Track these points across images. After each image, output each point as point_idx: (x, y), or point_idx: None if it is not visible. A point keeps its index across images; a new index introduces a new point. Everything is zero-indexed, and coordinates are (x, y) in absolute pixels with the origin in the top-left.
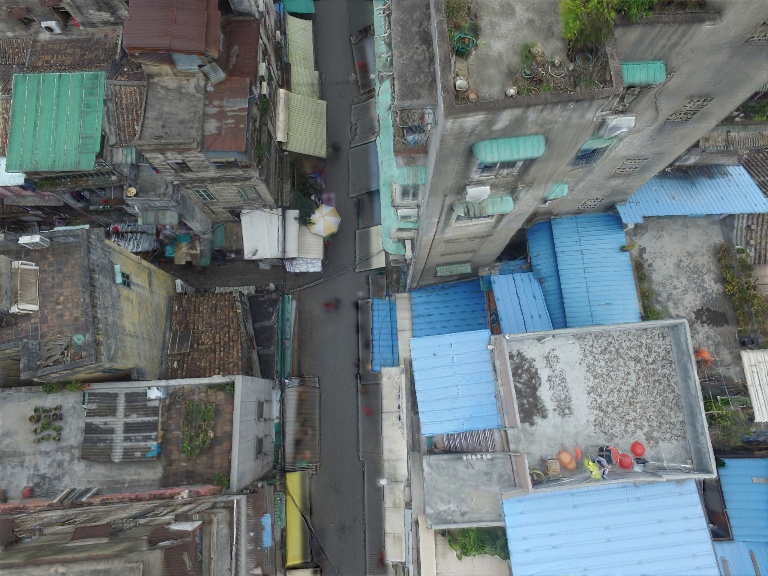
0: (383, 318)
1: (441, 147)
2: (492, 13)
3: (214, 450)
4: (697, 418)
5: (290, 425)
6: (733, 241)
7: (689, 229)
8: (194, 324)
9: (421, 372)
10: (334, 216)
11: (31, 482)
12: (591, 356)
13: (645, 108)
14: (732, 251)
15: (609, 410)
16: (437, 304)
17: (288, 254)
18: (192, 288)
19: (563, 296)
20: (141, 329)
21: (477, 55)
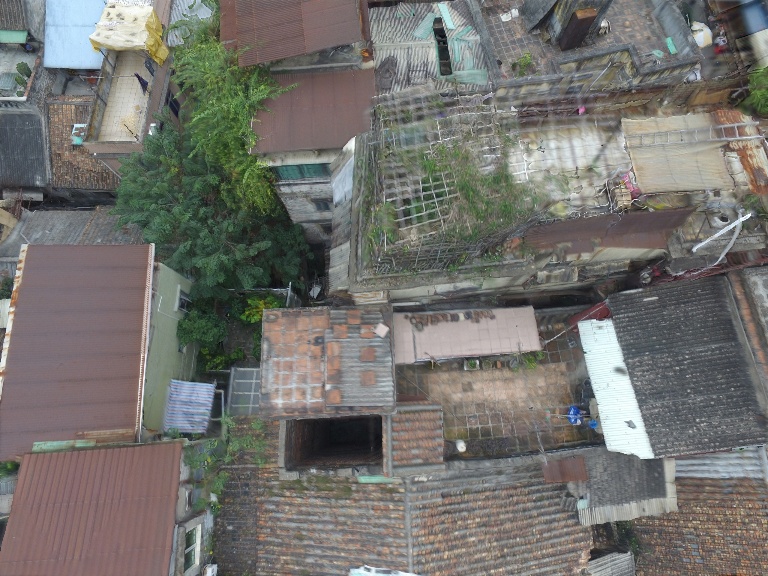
0: None
1: None
2: None
3: None
4: None
5: None
6: None
7: None
8: None
9: None
10: (709, 29)
11: None
12: None
13: None
14: None
15: None
16: None
17: None
18: None
19: None
20: None
21: None
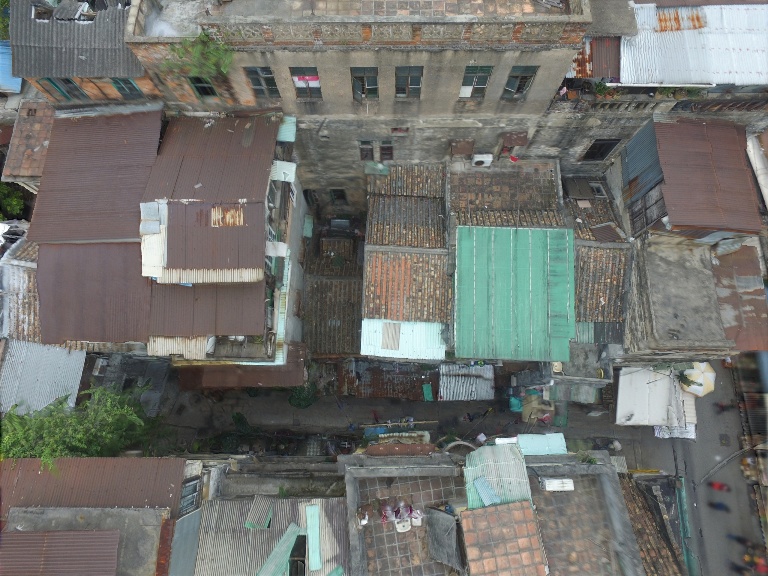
0: None
1: None
2: None
3: None
4: None
5: None
6: None
7: None
8: None
9: None
10: (712, 371)
11: None
12: None
13: None
14: None
15: None
16: None
17: (671, 422)
18: None
19: None
20: None
21: None
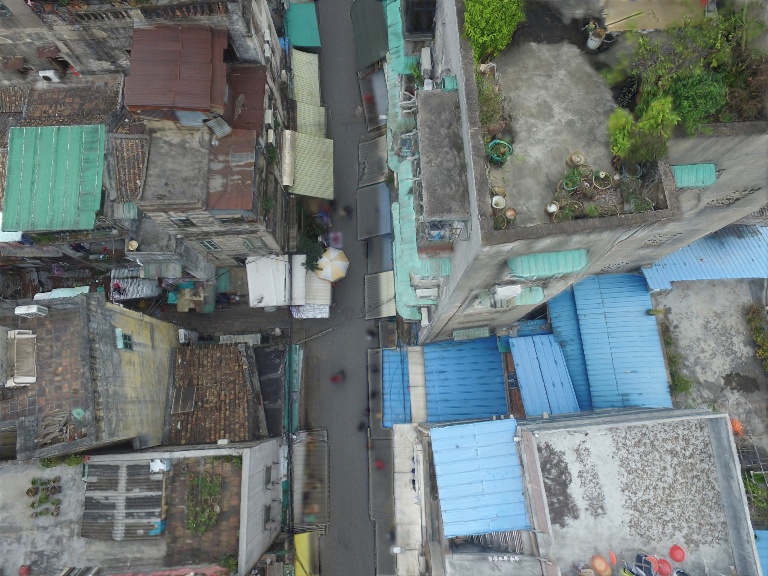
0: (394, 371)
1: (474, 262)
2: (527, 112)
3: (221, 526)
4: (741, 523)
5: (298, 483)
6: (762, 301)
7: (716, 287)
8: (198, 379)
9: (443, 466)
10: (342, 260)
11: (28, 560)
12: (624, 449)
13: (687, 198)
14: (762, 312)
15: (645, 510)
16: (451, 360)
17: (295, 301)
18: (195, 333)
19: (586, 363)
20: (143, 392)
21: (512, 161)
